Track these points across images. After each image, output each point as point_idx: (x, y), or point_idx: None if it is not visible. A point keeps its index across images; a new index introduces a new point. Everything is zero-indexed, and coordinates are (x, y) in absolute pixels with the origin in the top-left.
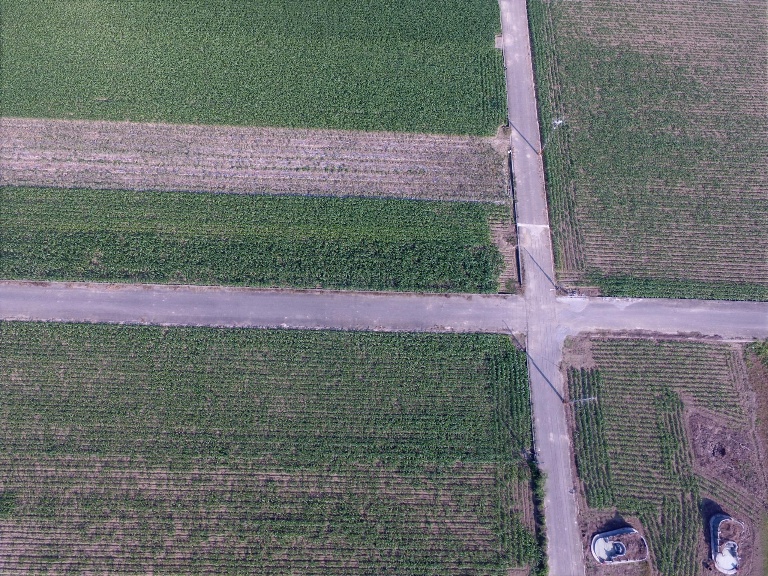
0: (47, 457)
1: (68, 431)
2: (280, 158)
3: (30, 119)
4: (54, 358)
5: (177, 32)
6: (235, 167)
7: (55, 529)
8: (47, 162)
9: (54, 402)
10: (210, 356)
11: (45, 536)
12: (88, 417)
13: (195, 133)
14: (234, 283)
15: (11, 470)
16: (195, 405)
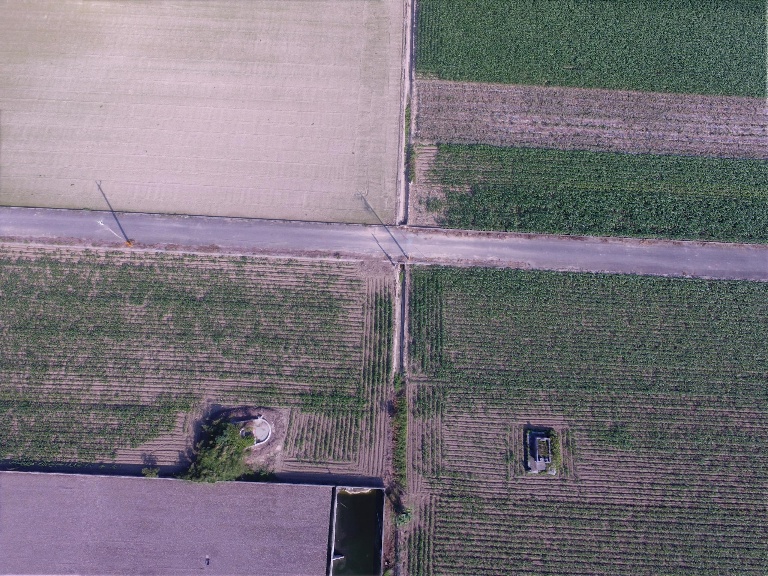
0: (641, 396)
1: (651, 373)
2: (755, 125)
3: (508, 85)
4: (617, 306)
5: (620, 4)
6: (717, 133)
7: (675, 460)
8: (539, 126)
9: (632, 346)
10: (760, 307)
11: (667, 466)
12: (668, 360)
13: (667, 101)
14: (761, 241)
15: (613, 407)
16: (763, 352)
